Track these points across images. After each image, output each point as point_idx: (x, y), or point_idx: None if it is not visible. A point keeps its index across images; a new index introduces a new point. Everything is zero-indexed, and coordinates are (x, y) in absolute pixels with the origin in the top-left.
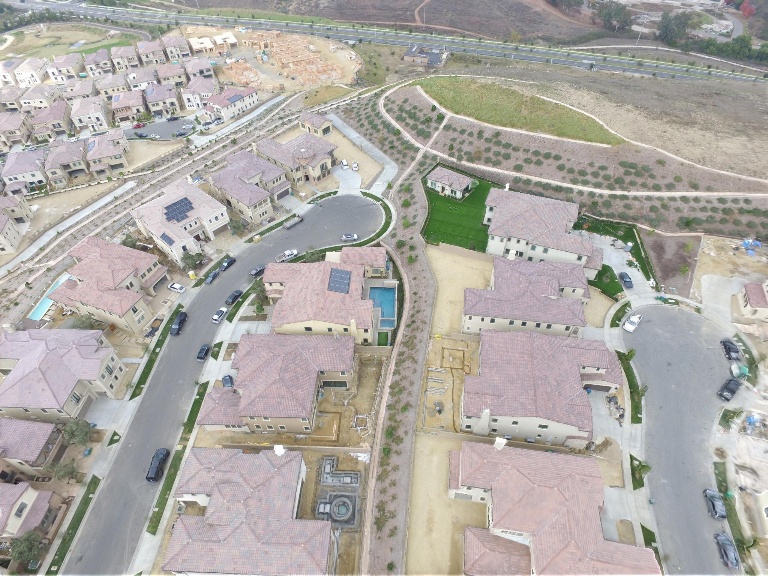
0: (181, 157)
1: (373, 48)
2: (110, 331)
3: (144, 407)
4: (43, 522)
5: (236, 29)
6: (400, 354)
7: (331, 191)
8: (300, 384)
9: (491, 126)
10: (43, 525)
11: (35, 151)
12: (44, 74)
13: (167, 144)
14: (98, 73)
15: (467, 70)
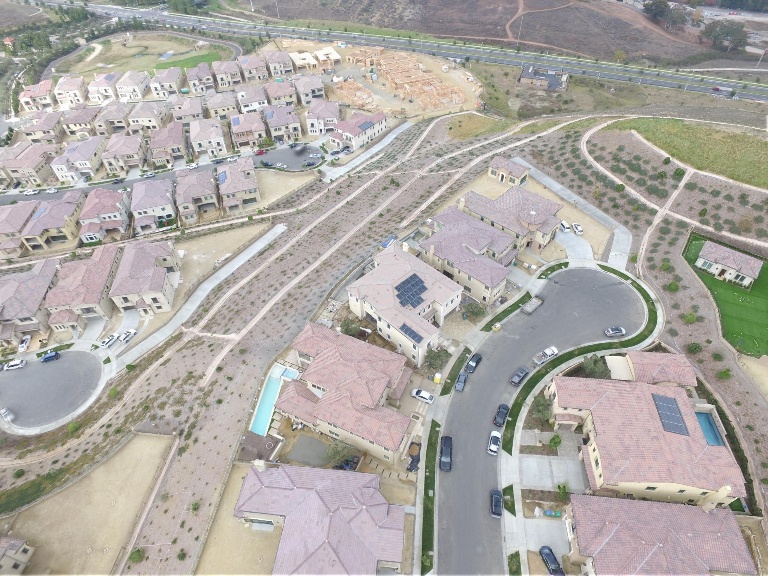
0: (321, 193)
1: (482, 67)
2: (363, 460)
3: None
4: None
5: (335, 44)
6: None
7: (560, 262)
8: None
9: (755, 189)
10: None
11: (162, 181)
12: (144, 88)
13: (297, 175)
14: (200, 89)
15: (675, 110)
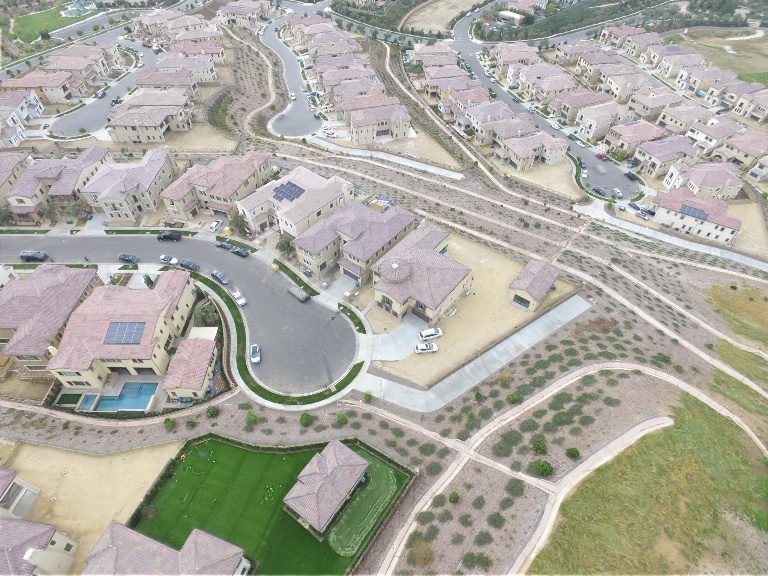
0: None
1: None
2: None
3: (94, 239)
4: (20, 216)
5: None
6: (31, 414)
7: (366, 326)
8: (5, 315)
9: None
10: (21, 217)
11: (508, 110)
12: None
13: (573, 186)
14: (713, 100)
15: None
